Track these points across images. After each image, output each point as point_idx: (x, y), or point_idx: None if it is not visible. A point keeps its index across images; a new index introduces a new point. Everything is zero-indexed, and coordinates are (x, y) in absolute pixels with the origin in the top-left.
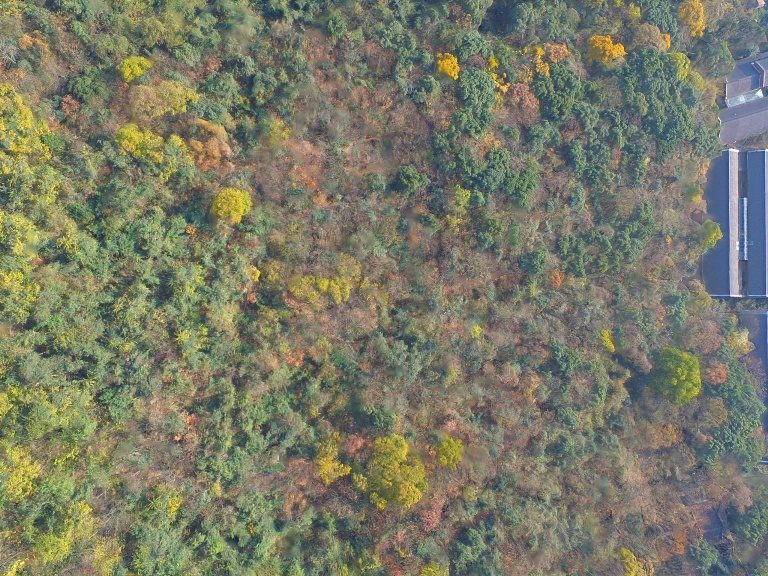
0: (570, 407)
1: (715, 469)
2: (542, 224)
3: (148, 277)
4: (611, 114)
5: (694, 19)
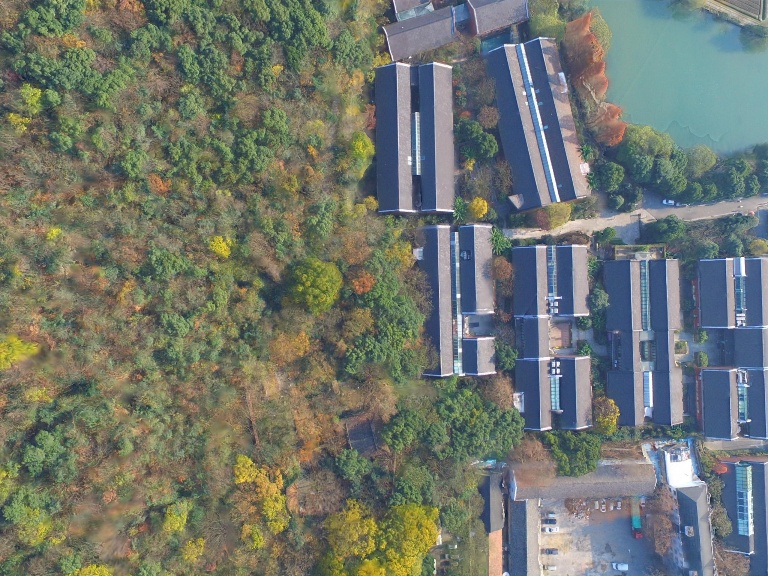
0: (175, 312)
1: (388, 384)
2: (148, 129)
3: None
4: (226, 18)
5: None
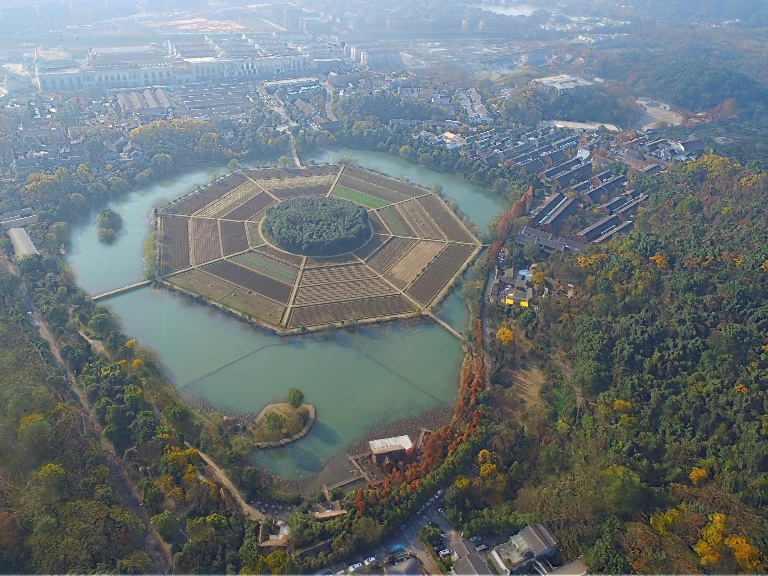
0: None
1: None
2: None
3: None
4: None
5: None
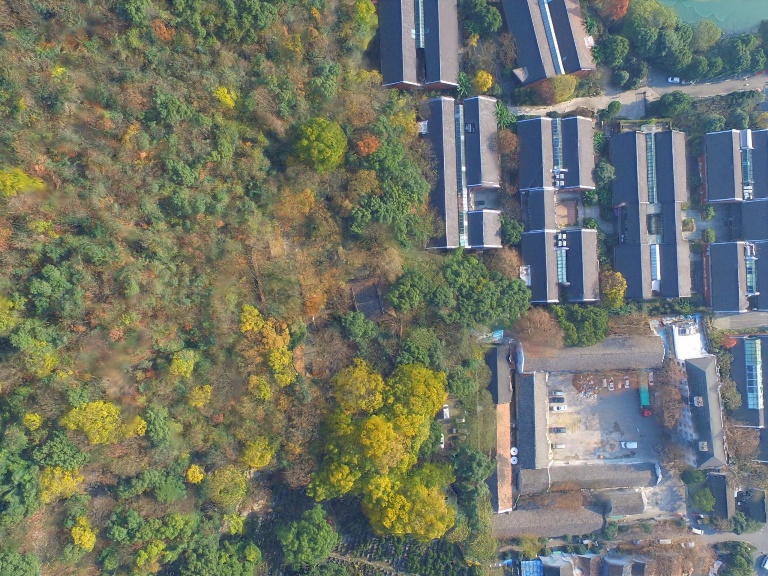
0: (180, 160)
1: None
2: None
3: None
4: None
5: None
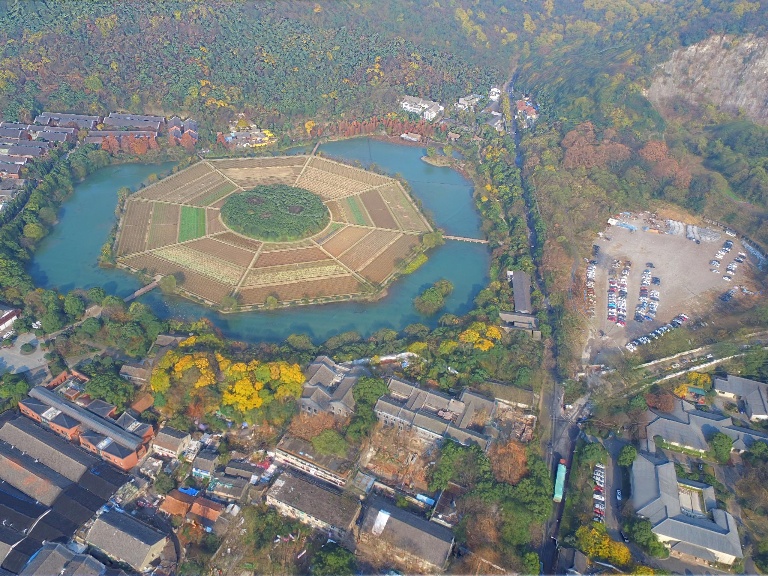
0: None
1: None
2: None
3: (166, 3)
4: None
5: None
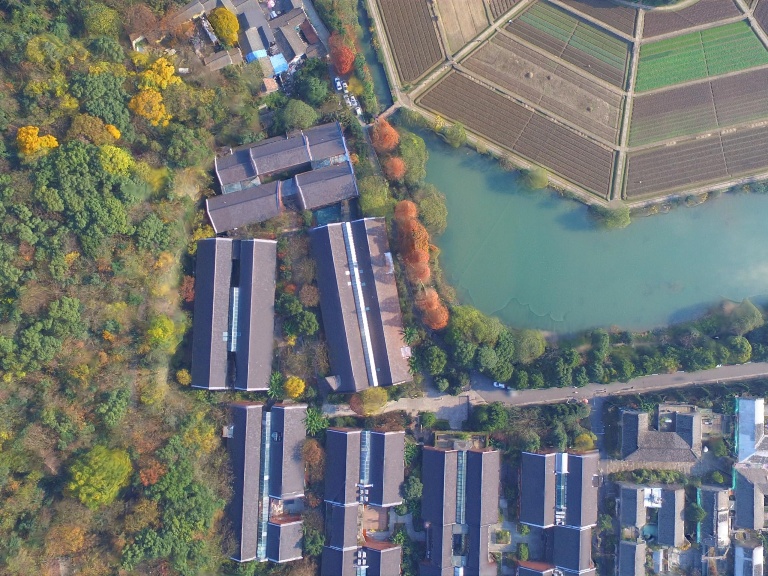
0: None
1: None
2: None
3: None
4: (15, 210)
5: (147, 109)
